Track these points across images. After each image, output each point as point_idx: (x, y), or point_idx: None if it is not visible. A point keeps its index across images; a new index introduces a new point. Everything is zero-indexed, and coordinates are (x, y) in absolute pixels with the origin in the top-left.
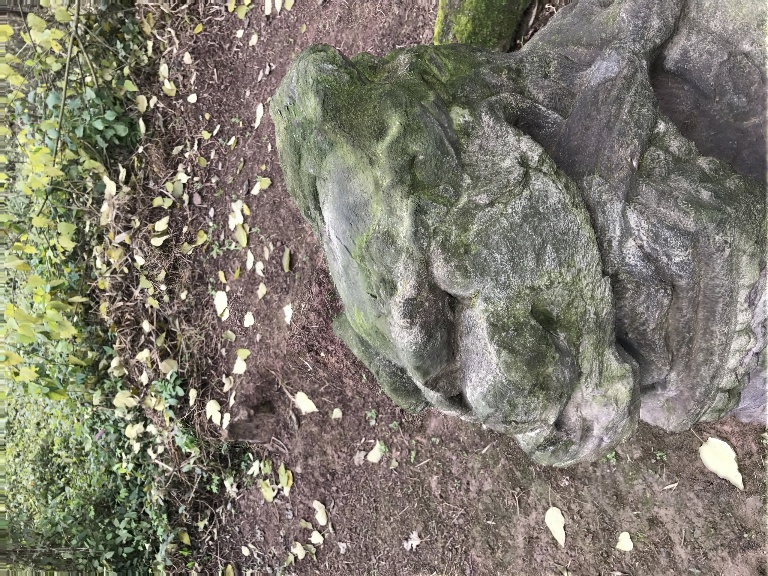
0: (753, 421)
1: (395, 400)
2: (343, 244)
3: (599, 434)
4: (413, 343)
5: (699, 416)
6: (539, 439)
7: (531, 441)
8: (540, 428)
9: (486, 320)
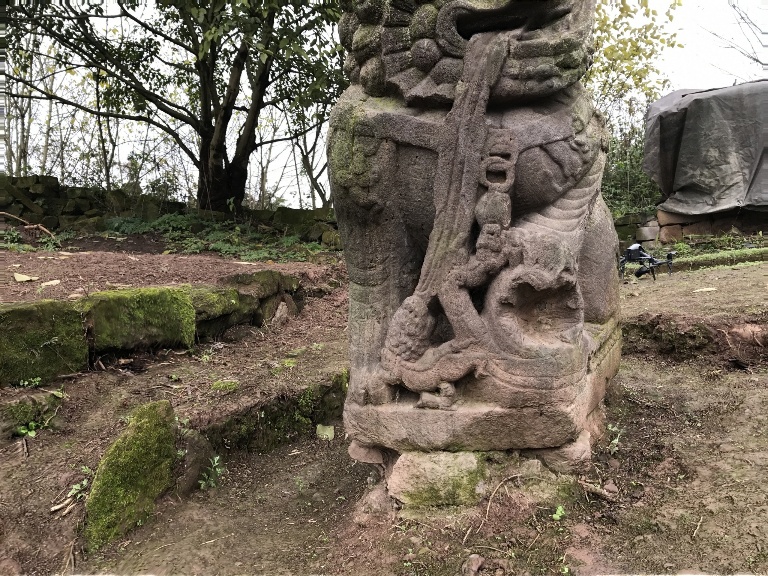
0: (521, 247)
1: None
2: None
3: None
4: None
5: (577, 40)
6: None
7: None
8: None
9: None
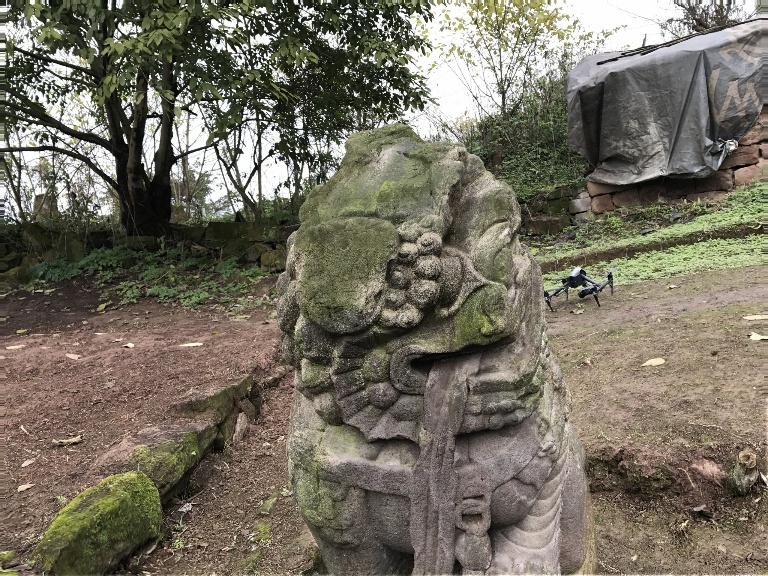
0: None
1: (390, 230)
2: (402, 152)
3: (521, 276)
4: (460, 162)
5: None
6: (505, 240)
7: (499, 243)
8: (509, 229)
9: (491, 175)
